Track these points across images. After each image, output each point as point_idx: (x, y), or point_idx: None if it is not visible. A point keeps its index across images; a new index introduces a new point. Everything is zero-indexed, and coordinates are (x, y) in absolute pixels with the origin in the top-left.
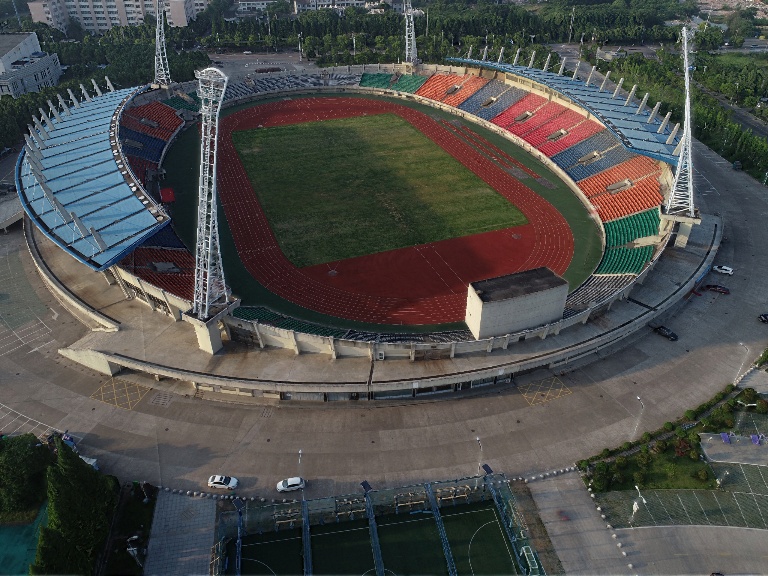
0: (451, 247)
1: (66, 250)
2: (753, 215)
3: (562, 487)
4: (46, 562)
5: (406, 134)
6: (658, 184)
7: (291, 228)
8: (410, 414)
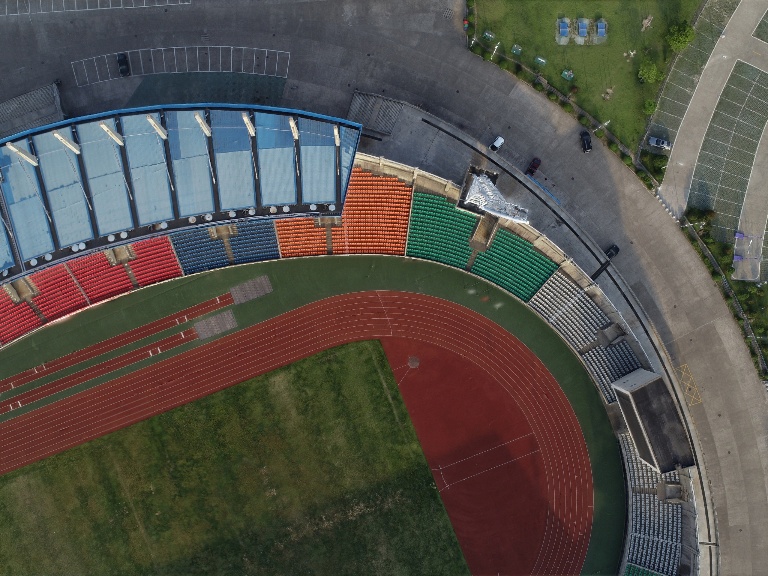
0: (441, 446)
1: None
2: (353, 38)
3: None
4: None
5: (43, 492)
6: (357, 170)
7: None
8: None
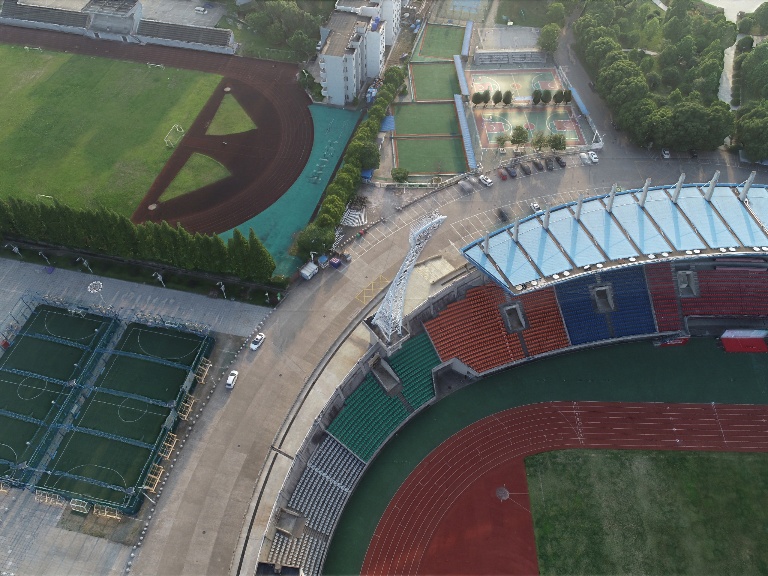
0: None
1: (500, 229)
2: None
3: (112, 575)
4: (203, 241)
5: None
6: None
7: (631, 474)
8: (250, 487)
